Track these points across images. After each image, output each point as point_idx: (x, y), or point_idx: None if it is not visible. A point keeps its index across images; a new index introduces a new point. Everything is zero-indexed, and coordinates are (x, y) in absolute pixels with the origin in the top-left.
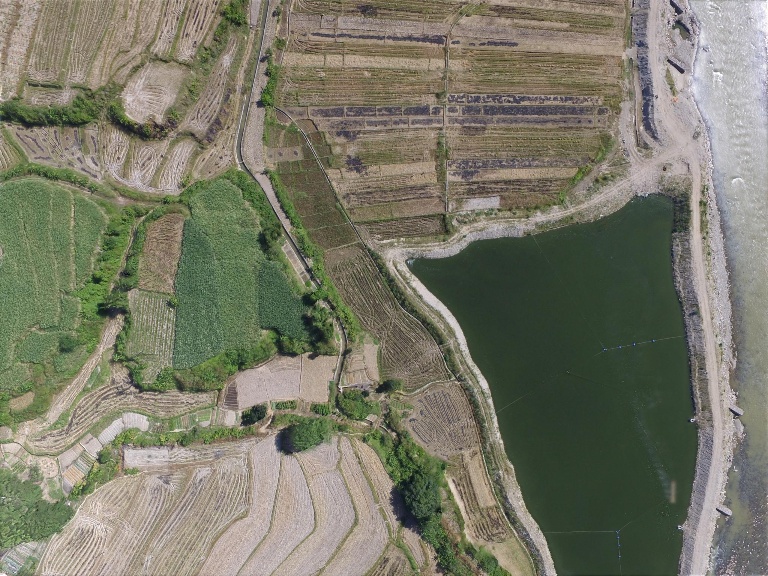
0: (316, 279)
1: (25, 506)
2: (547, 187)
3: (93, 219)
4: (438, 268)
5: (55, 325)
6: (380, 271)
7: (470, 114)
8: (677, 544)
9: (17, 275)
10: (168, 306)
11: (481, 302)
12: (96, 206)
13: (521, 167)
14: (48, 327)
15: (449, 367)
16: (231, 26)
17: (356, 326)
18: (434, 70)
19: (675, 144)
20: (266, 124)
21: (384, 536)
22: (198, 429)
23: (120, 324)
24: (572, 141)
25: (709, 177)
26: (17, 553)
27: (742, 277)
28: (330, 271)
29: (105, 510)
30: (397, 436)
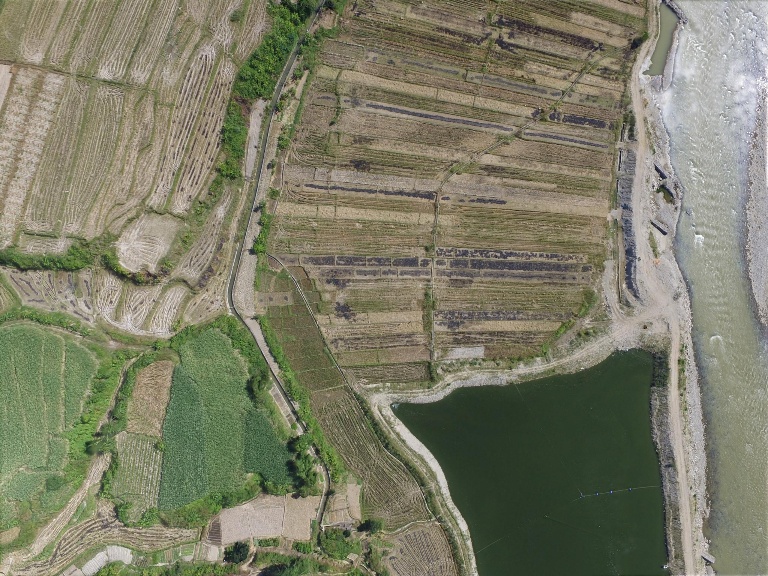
0: (302, 421)
1: None
2: (531, 339)
3: (84, 365)
4: (422, 413)
5: (43, 466)
6: (365, 414)
7: (458, 267)
8: None
9: (7, 417)
10: (155, 449)
11: (463, 447)
12: (87, 352)
13: (506, 319)
14: (36, 468)
15: (430, 508)
16: (226, 179)
17: (340, 467)
18: (424, 224)
19: (656, 304)
20: (258, 270)
21: None
22: (181, 564)
23: (107, 460)
24: (556, 296)
25: (688, 335)
26: None
27: (718, 430)
28: (316, 412)
29: None
30: (377, 575)
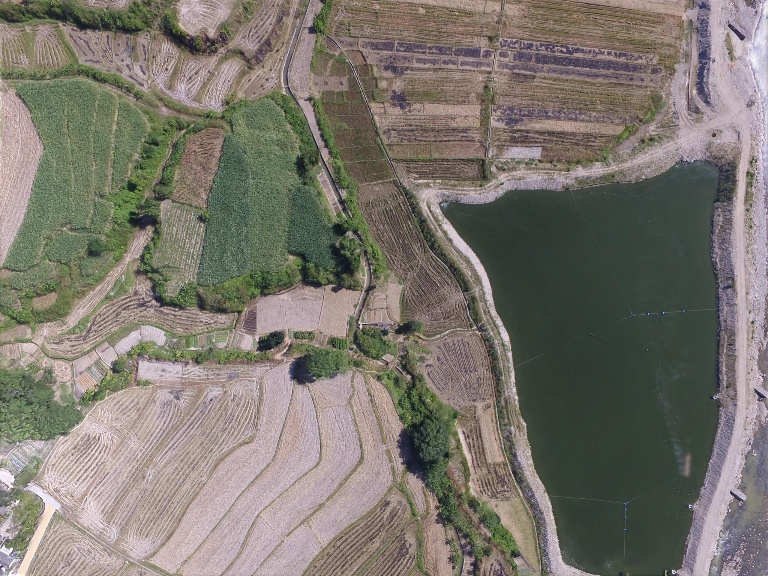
0: (348, 211)
1: (37, 403)
2: (591, 142)
3: (135, 125)
4: (471, 214)
5: (86, 227)
6: (413, 211)
7: (521, 61)
8: (686, 523)
9: (55, 173)
10: (199, 221)
11: (511, 253)
12: (140, 113)
13: (567, 119)
14: (79, 228)
15: (472, 316)
16: None
17: (382, 264)
18: (489, 13)
19: (727, 111)
20: (315, 51)
21: (388, 478)
22: (214, 349)
23: (149, 235)
24: (622, 98)
25: (759, 149)
26: (23, 451)
27: None
28: (362, 206)
29: (113, 419)
30: (412, 379)
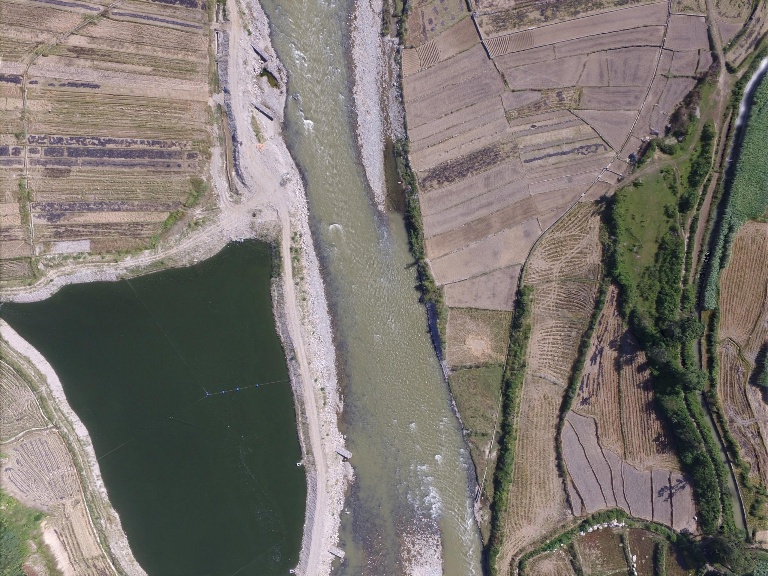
0: None
1: None
2: (138, 231)
3: None
4: (29, 312)
5: None
6: None
7: (53, 156)
8: None
9: None
10: None
11: (76, 347)
12: None
13: (110, 210)
14: None
15: (45, 414)
16: None
17: None
18: (12, 110)
19: (263, 190)
20: None
21: None
22: None
23: None
24: (161, 185)
25: (304, 223)
26: None
27: (345, 322)
28: None
29: None
30: None
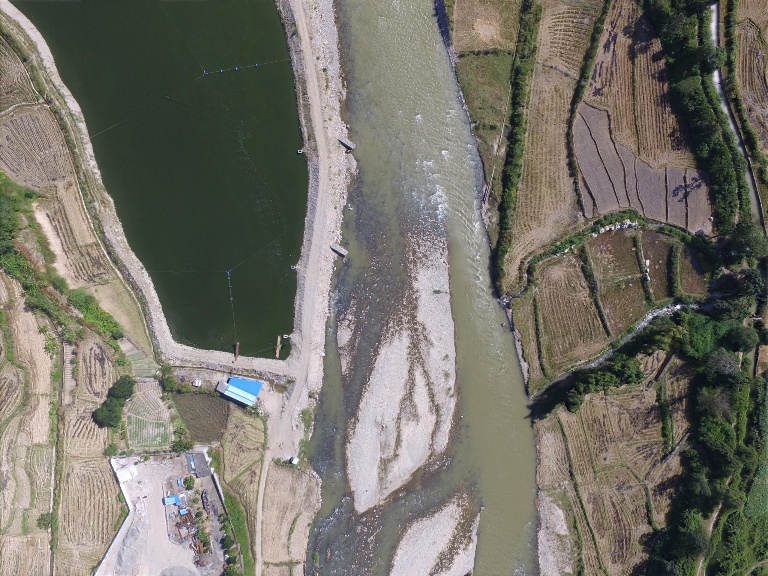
0: None
1: None
2: None
3: None
4: None
5: None
6: None
7: None
8: (291, 286)
9: None
10: None
11: (68, 16)
12: None
13: None
14: None
15: (36, 87)
16: None
17: None
18: None
19: None
20: None
21: None
22: None
23: None
24: None
25: None
26: None
27: (348, 1)
28: None
29: None
30: None
